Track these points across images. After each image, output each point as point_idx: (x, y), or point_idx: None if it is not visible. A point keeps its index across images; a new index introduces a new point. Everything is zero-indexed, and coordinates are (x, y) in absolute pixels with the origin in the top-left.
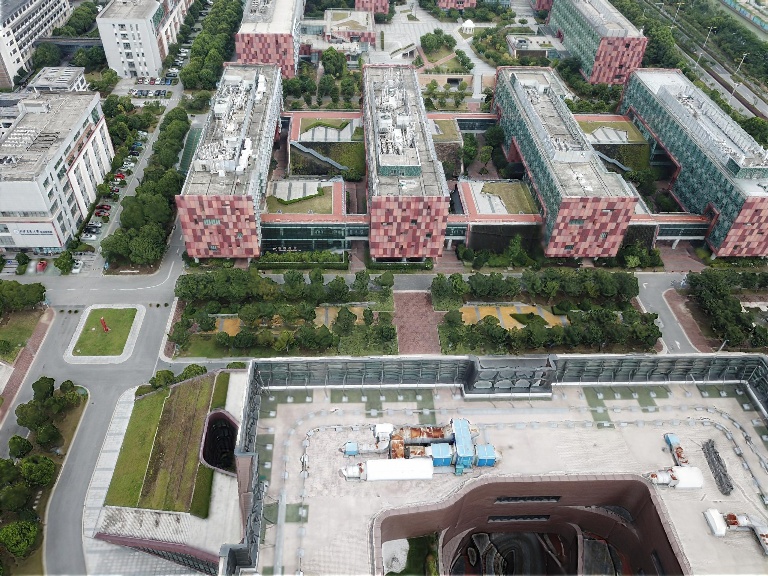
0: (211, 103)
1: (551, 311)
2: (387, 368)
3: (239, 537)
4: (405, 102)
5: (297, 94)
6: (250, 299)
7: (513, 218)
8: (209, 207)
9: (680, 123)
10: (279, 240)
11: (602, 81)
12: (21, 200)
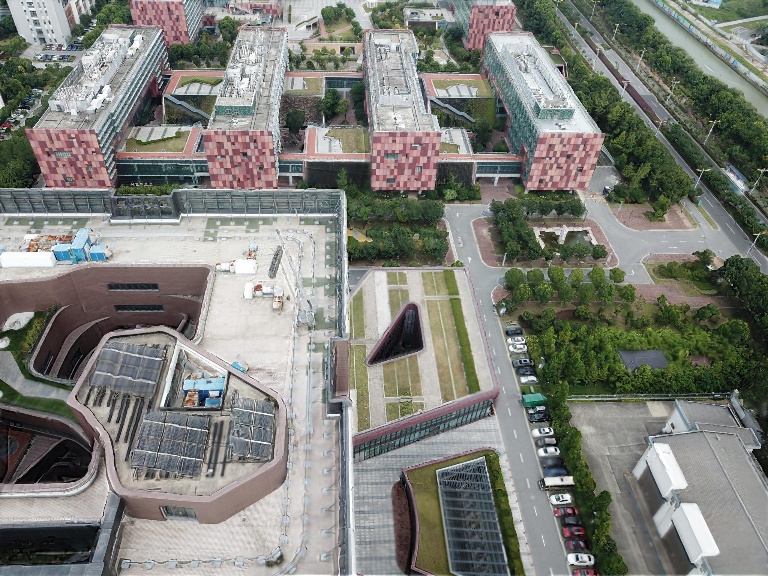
0: None
1: (365, 233)
2: (47, 198)
3: None
4: (264, 57)
5: (189, 58)
6: None
7: (346, 156)
8: (57, 140)
9: (510, 75)
10: (135, 176)
11: (478, 47)
12: None
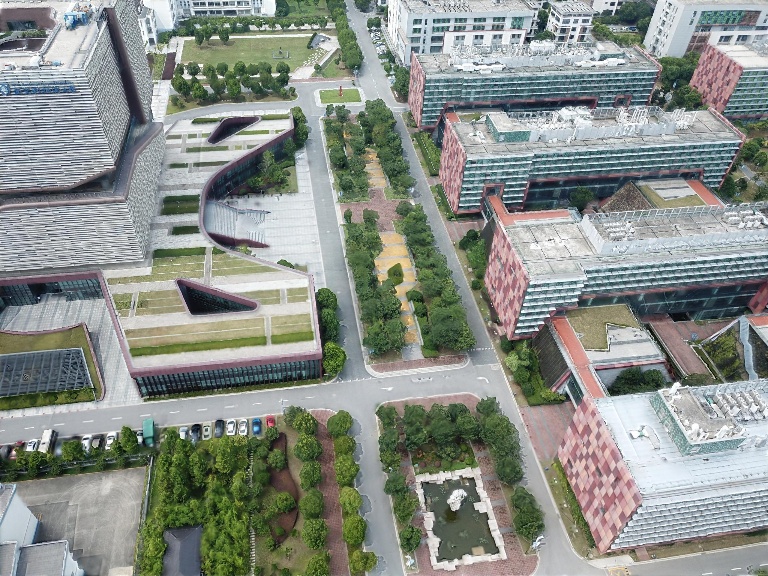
0: None
1: None
2: None
3: None
4: None
5: None
6: None
7: None
8: None
9: None
10: None
11: None
12: None
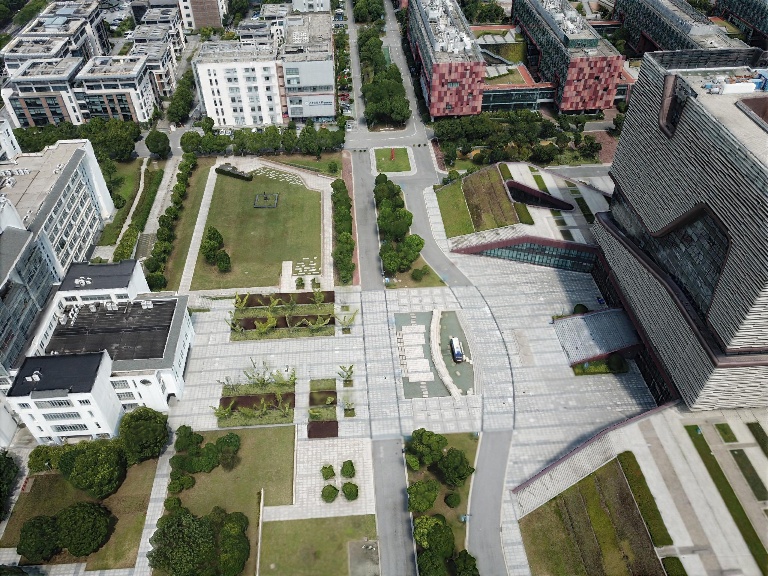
0: (385, 29)
1: None
2: (712, 56)
3: (558, 231)
4: (561, 7)
5: None
6: (483, 138)
7: None
8: (455, 72)
9: None
10: (488, 105)
11: None
12: (318, 76)
